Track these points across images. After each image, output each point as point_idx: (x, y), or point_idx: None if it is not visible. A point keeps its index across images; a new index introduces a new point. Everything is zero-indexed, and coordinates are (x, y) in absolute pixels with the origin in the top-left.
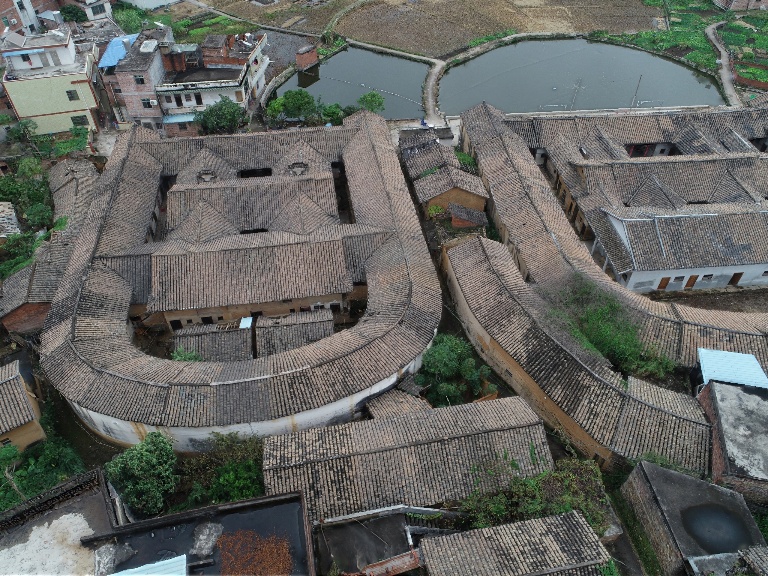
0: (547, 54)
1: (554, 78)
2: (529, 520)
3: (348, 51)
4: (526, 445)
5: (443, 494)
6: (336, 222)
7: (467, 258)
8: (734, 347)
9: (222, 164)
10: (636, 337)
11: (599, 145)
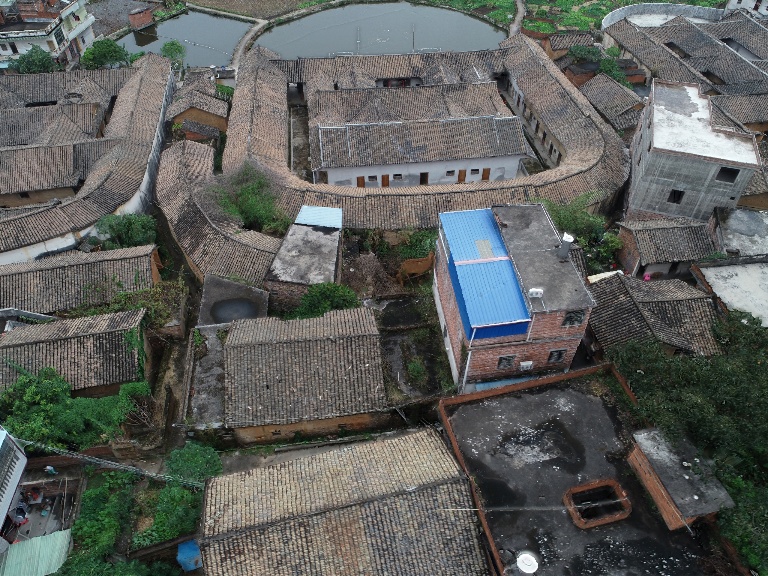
0: (366, 14)
1: (362, 33)
2: (104, 314)
3: (189, 15)
4: (133, 271)
5: (56, 305)
6: (90, 138)
7: (171, 156)
8: (339, 207)
9: (12, 97)
10: (272, 205)
11: (349, 79)
